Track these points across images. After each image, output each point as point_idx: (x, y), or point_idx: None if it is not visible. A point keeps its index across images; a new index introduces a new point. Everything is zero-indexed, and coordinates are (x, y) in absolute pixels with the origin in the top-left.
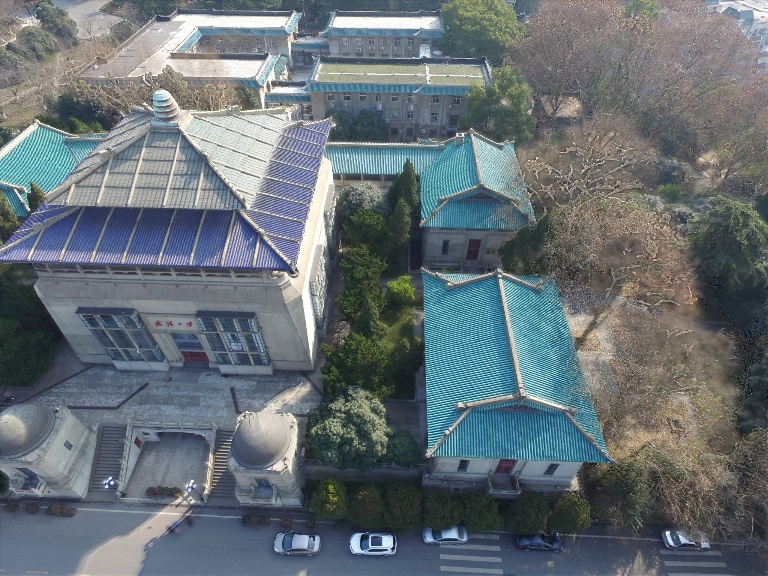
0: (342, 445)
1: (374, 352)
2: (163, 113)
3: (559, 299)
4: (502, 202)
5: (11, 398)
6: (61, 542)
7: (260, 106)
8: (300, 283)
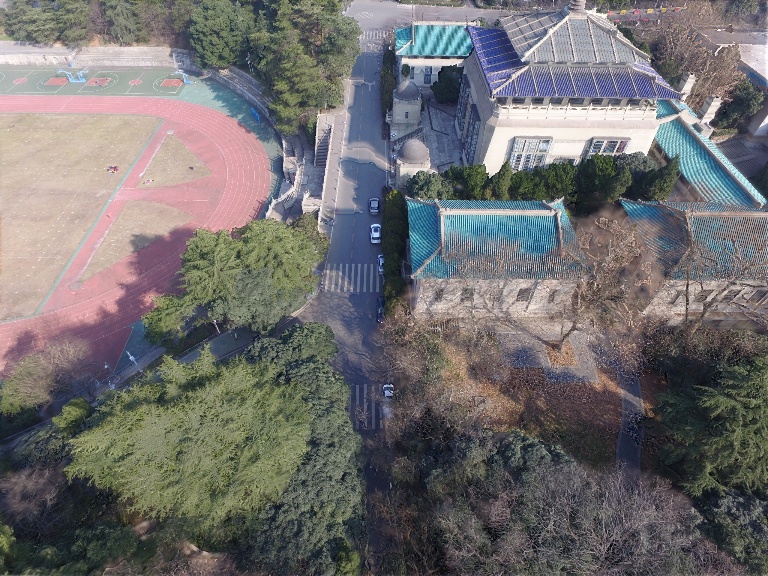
0: (415, 183)
1: (474, 178)
2: (571, 4)
3: (565, 277)
4: (684, 243)
5: (430, 100)
6: (372, 140)
7: (763, 119)
8: (504, 124)
